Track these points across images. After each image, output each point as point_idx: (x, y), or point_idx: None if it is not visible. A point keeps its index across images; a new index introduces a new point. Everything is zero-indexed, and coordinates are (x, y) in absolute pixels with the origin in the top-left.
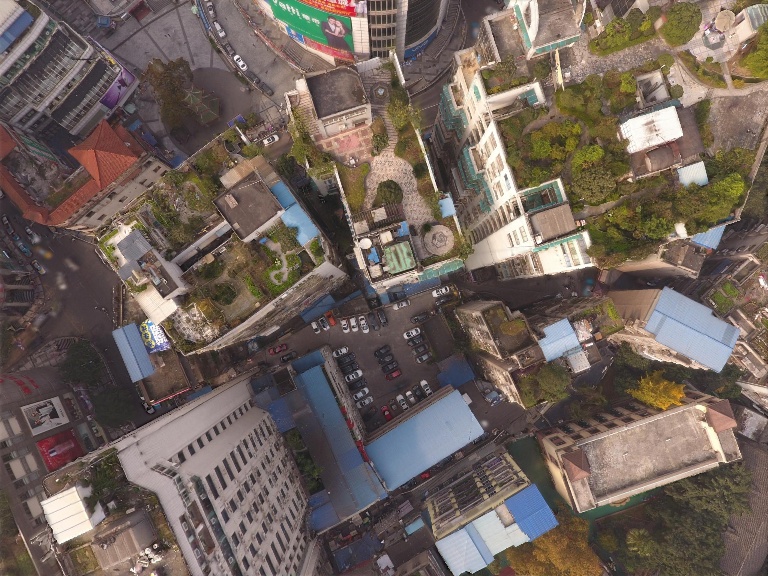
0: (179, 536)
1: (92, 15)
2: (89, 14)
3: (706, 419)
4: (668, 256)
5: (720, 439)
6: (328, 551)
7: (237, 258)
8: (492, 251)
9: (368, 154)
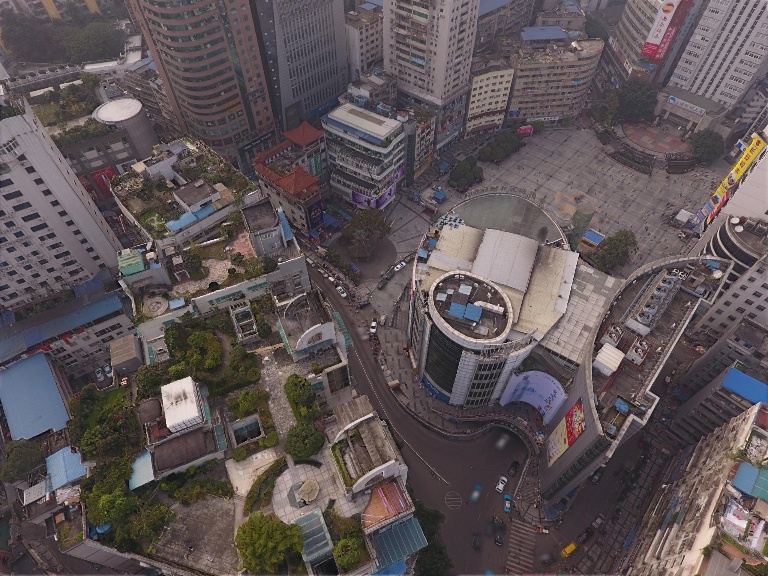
0: None
1: None
2: None
3: None
4: None
5: None
6: None
7: None
8: None
9: None
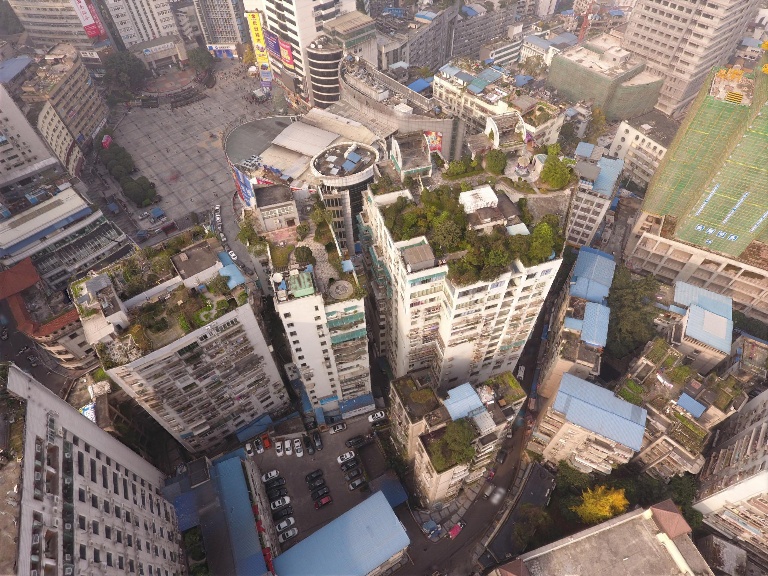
0: (29, 444)
1: (135, 231)
2: (133, 231)
3: (655, 523)
4: None
5: (681, 552)
6: None
7: (177, 303)
8: (401, 334)
9: (294, 241)
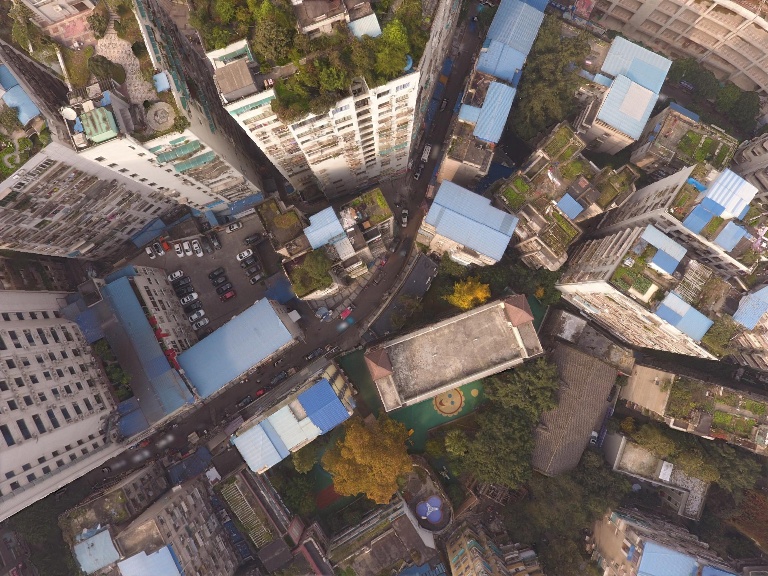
0: None
1: None
2: None
3: (504, 314)
4: (456, 154)
5: (521, 335)
6: (165, 468)
7: None
8: None
9: (93, 37)
